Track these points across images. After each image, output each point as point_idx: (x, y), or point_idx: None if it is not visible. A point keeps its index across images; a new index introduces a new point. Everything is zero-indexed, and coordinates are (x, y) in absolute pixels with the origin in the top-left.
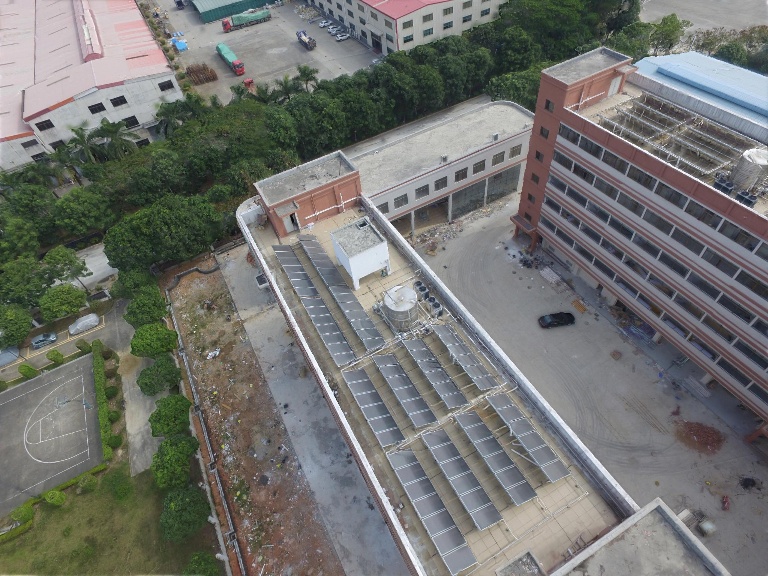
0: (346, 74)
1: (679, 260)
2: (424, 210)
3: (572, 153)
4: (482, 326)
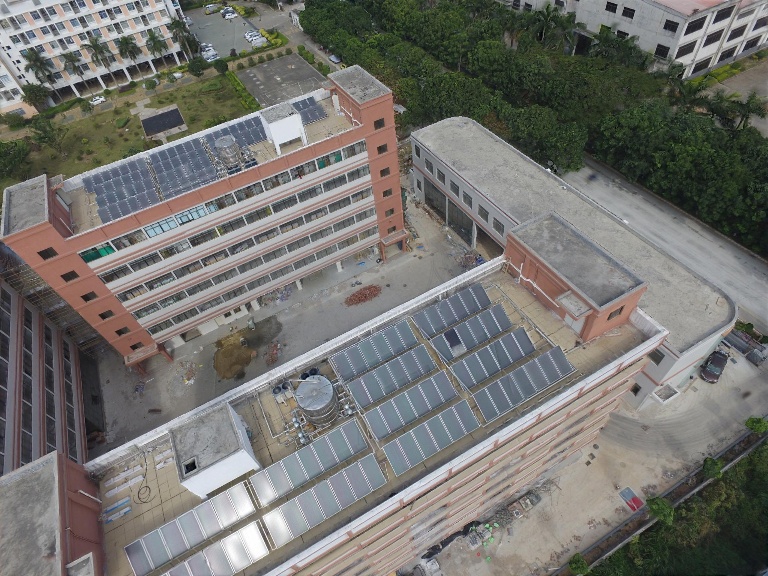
0: None
1: None
2: None
3: None
4: None
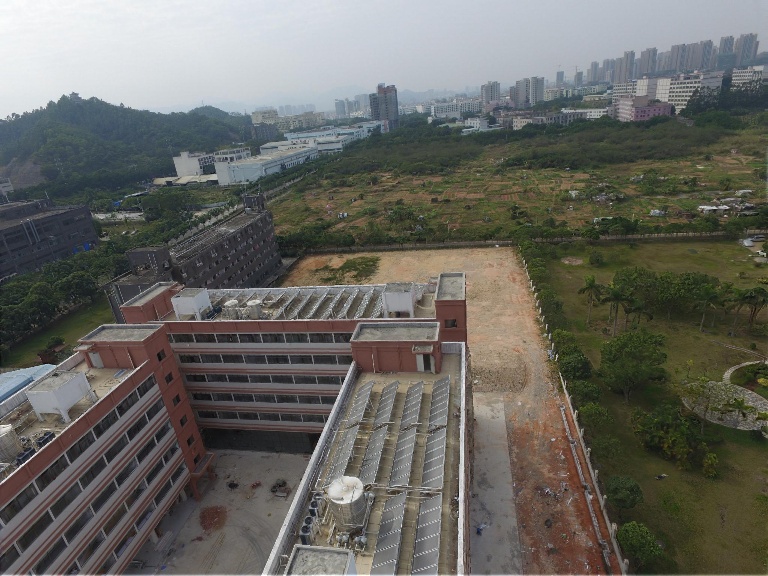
0: None
1: (79, 514)
2: None
3: None
4: None
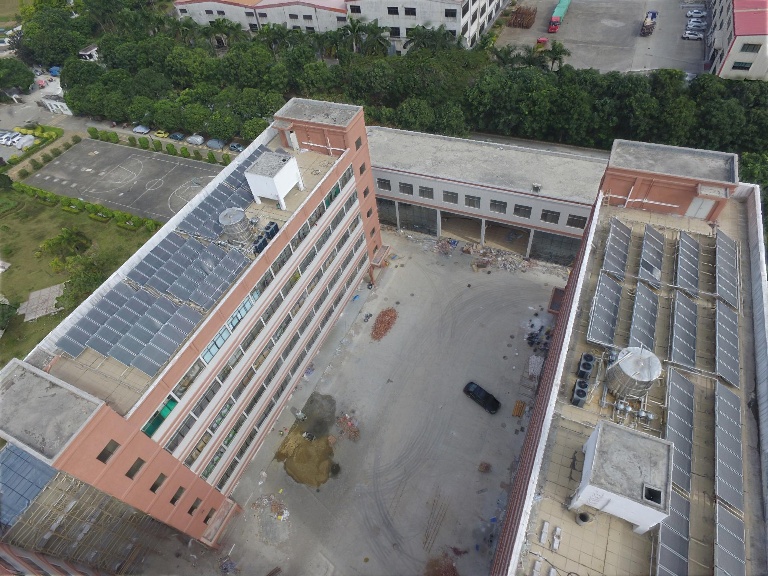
0: (598, 70)
1: None
2: (520, 232)
3: (583, 246)
4: (428, 346)
